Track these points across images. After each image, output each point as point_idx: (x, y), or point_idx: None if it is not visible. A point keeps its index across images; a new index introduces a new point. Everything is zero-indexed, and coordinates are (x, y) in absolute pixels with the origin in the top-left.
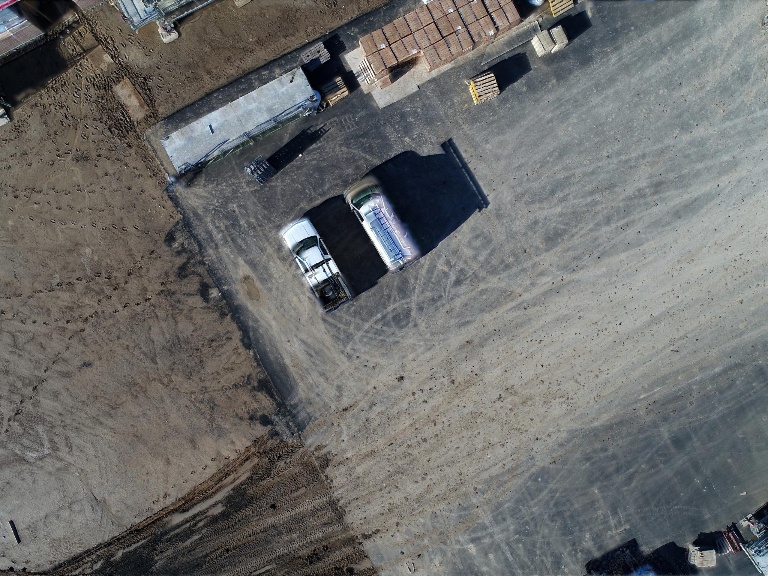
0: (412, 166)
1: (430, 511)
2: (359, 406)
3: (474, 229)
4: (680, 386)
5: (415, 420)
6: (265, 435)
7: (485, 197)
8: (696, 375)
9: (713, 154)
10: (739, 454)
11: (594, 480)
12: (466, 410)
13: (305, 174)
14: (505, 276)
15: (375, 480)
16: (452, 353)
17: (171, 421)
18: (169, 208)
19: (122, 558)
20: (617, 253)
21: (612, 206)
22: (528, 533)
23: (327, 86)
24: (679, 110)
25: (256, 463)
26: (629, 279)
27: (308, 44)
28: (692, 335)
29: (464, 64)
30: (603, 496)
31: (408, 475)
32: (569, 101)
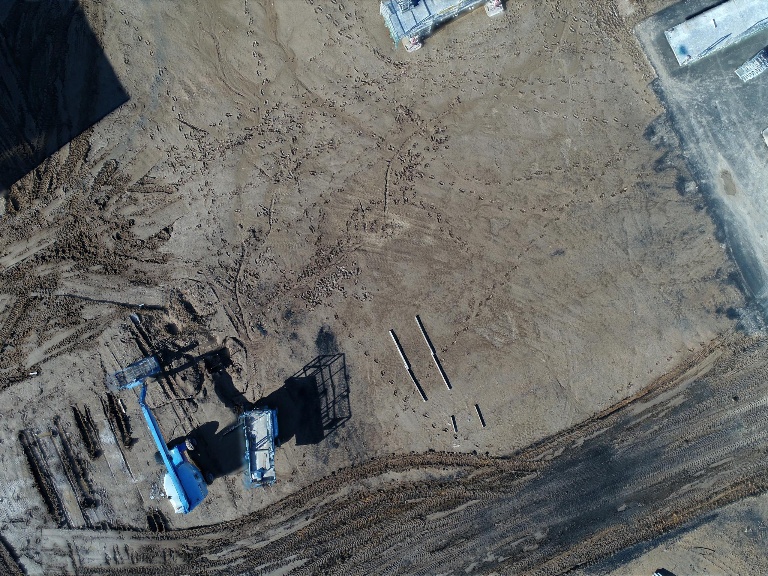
0: None
1: None
2: None
3: None
4: None
5: None
6: (730, 329)
7: None
8: None
9: None
10: None
11: None
12: None
13: None
14: None
15: None
16: None
17: (639, 311)
18: (652, 102)
19: (583, 446)
20: None
21: None
22: None
23: None
24: None
25: (720, 356)
26: None
27: None
28: None
29: None
30: None
31: None
32: None
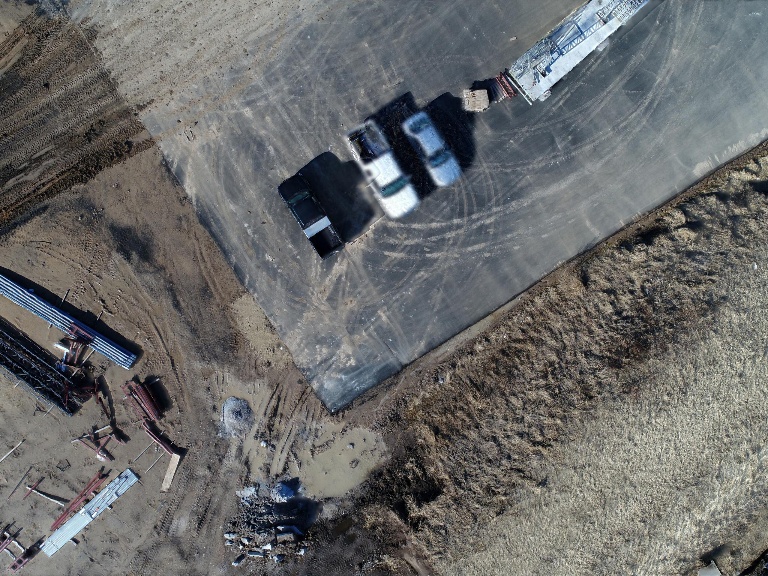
0: None
1: (202, 76)
2: None
3: None
4: None
5: None
6: (32, 15)
7: None
8: None
9: None
10: None
11: (363, 34)
12: None
13: None
14: None
15: (145, 49)
16: None
17: None
18: None
19: None
20: None
21: None
22: (303, 93)
23: None
24: None
25: (26, 44)
26: None
27: None
28: None
29: None
30: (374, 50)
31: (177, 41)
32: None
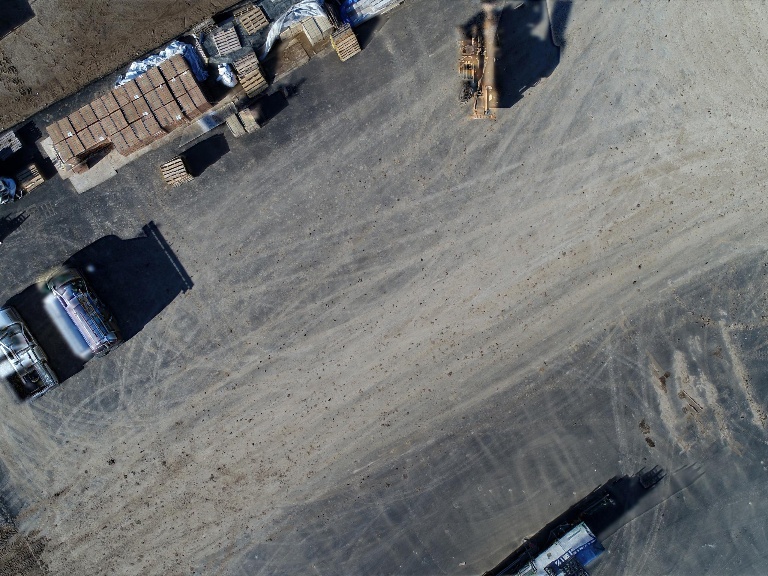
0: (114, 250)
1: None
2: (71, 490)
3: (179, 311)
4: (393, 460)
5: (128, 502)
6: None
7: (189, 278)
8: (408, 448)
9: (415, 228)
10: (456, 525)
11: (311, 556)
12: (179, 491)
13: (6, 262)
14: (212, 356)
15: (91, 563)
16: (162, 435)
17: None
18: None
19: None
20: (323, 330)
21: (316, 283)
22: None
23: (21, 174)
24: (380, 186)
25: None
26: (336, 355)
27: (3, 132)
28: (402, 409)
29: (161, 147)
30: (321, 571)
31: (123, 557)
32: (269, 180)
